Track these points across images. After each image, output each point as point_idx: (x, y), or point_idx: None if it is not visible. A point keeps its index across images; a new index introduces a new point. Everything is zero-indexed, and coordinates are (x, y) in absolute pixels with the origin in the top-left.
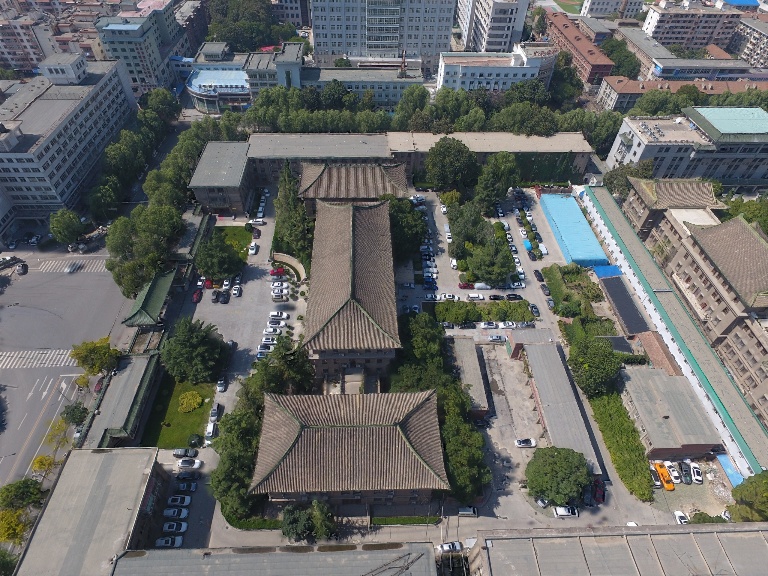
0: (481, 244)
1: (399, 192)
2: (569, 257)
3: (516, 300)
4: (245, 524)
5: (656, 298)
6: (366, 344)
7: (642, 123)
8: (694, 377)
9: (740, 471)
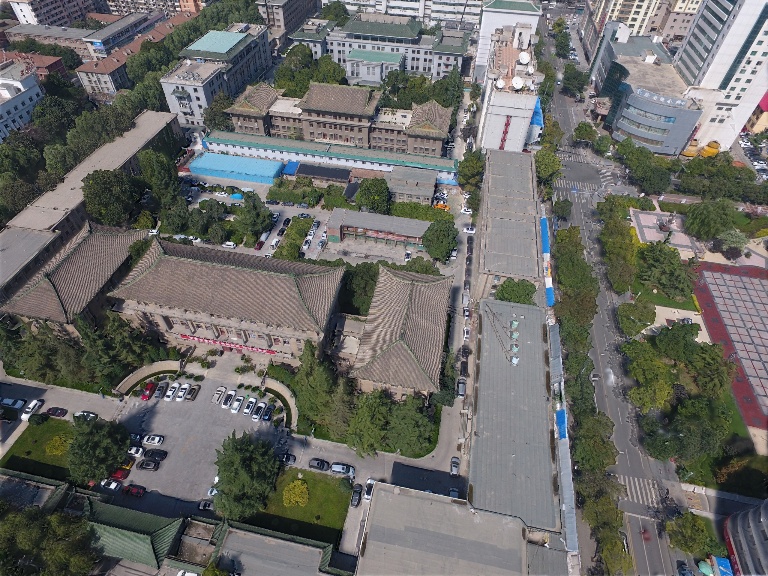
0: (218, 221)
1: (136, 236)
2: (268, 179)
3: (290, 222)
4: (435, 438)
5: (333, 153)
6: (333, 288)
7: (177, 76)
8: (391, 167)
9: (447, 179)
